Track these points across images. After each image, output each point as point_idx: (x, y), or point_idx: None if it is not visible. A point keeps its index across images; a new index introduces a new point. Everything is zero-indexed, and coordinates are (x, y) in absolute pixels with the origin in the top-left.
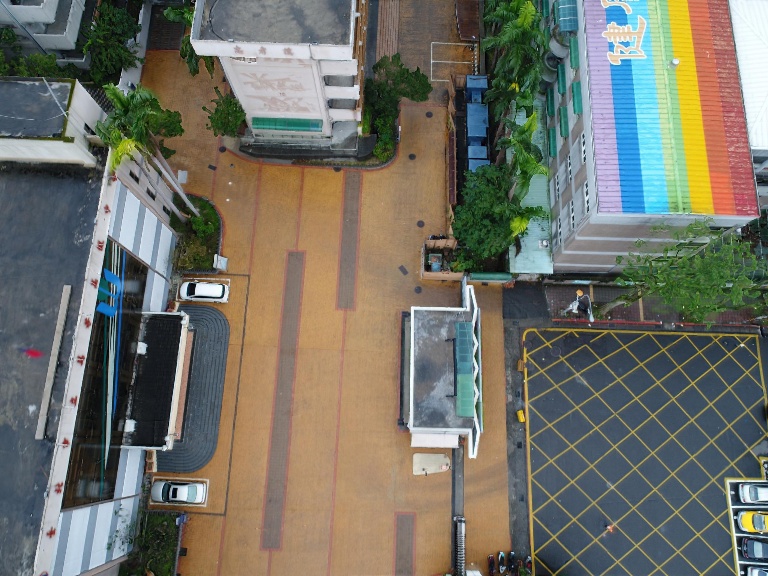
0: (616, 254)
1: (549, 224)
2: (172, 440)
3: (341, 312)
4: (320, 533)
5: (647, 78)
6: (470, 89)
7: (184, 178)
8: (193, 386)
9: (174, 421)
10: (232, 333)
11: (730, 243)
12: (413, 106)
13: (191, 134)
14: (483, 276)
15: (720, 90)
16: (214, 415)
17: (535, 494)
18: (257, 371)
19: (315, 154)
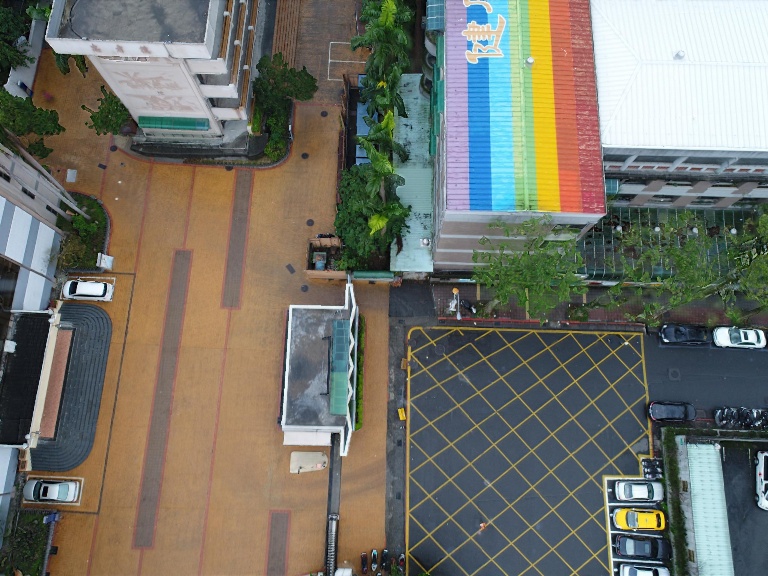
0: (490, 252)
1: (431, 223)
2: (36, 438)
3: (226, 311)
4: (193, 531)
5: (503, 77)
6: (362, 88)
7: (73, 177)
8: (69, 384)
9: (39, 419)
10: (114, 332)
11: (611, 241)
12: (308, 105)
13: (82, 133)
14: (365, 274)
15: (575, 88)
16: (91, 413)
17: (412, 492)
18: (138, 369)
19: (206, 153)
